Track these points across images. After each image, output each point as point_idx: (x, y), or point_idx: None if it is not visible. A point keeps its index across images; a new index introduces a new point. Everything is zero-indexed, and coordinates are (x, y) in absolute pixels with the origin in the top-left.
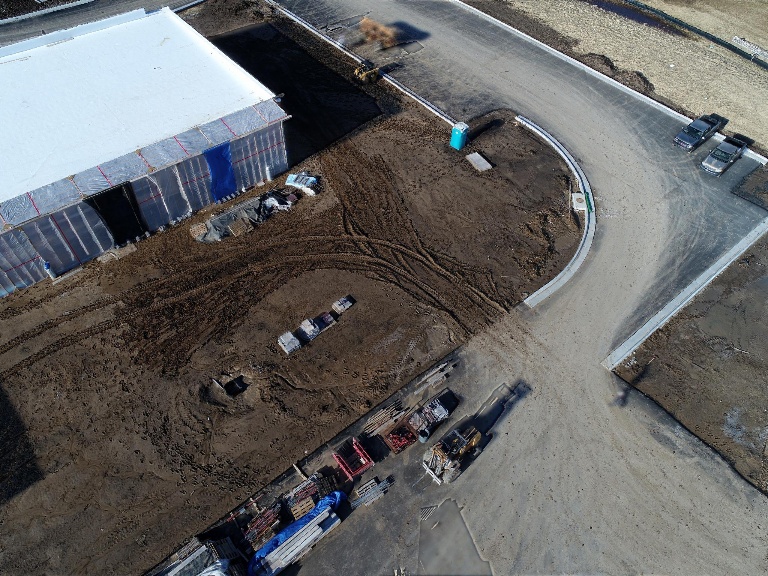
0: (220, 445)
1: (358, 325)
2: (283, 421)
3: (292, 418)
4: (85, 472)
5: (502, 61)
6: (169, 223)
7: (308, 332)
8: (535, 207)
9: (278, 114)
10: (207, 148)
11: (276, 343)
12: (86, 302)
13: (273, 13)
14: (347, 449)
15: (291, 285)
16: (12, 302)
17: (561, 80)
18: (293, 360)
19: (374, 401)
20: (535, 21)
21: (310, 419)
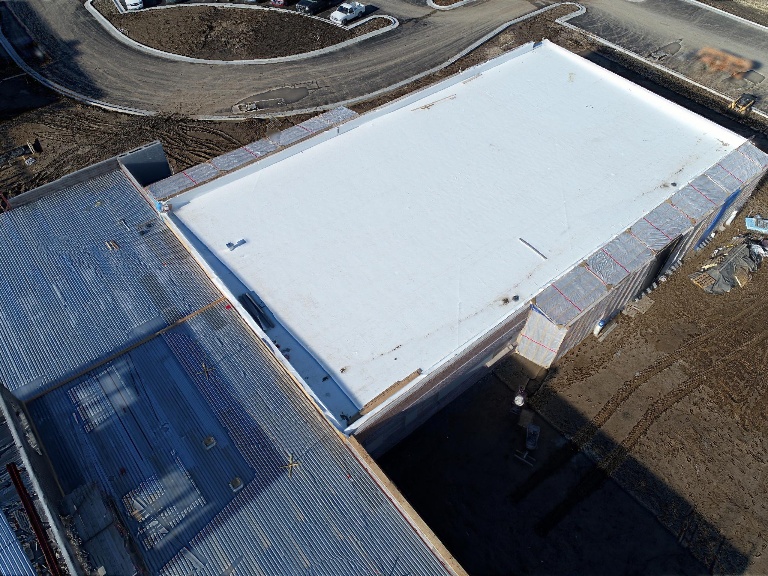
0: None
1: None
2: None
3: None
4: None
5: None
6: (665, 272)
7: None
8: None
9: (765, 158)
10: (727, 196)
11: None
12: (648, 361)
13: (587, 40)
14: None
15: None
16: (573, 362)
17: None
18: None
19: None
20: None
21: None
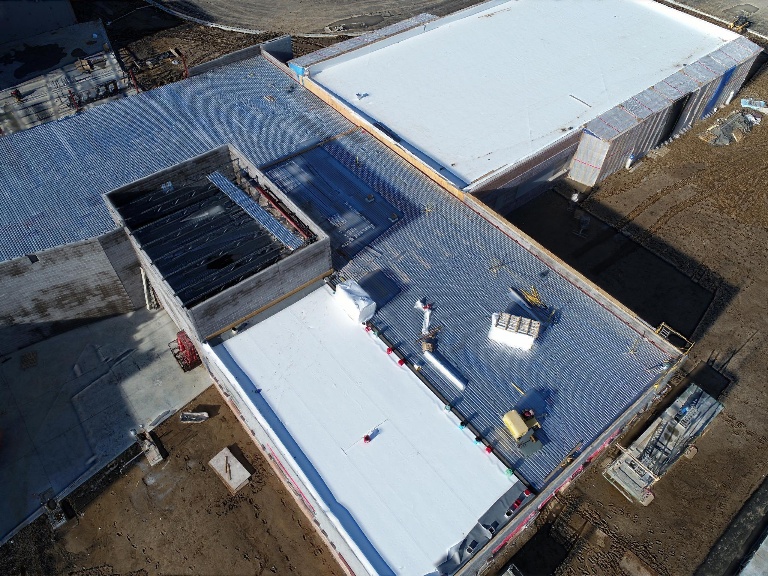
0: None
1: None
2: None
3: None
4: None
5: None
6: (679, 132)
7: None
8: None
9: (756, 47)
10: (725, 70)
11: None
12: (667, 184)
13: None
14: None
15: None
16: (611, 183)
17: None
18: None
19: None
20: None
21: None
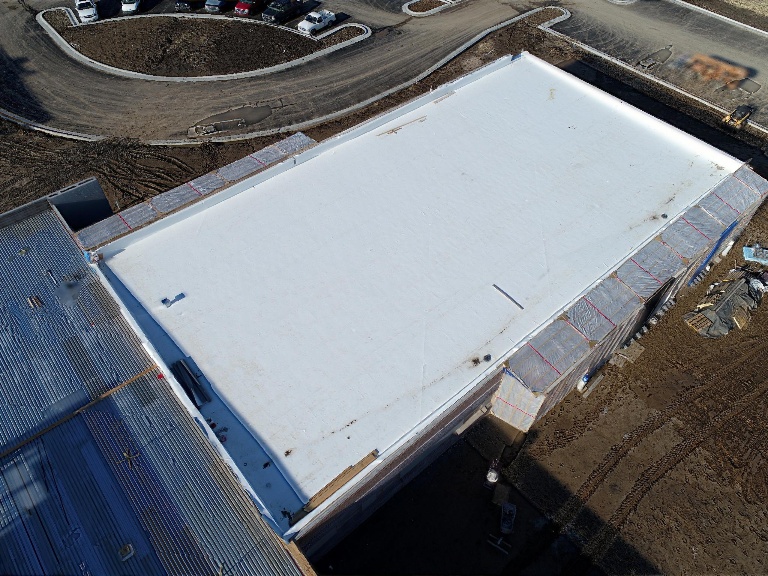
0: None
1: None
2: None
3: None
4: None
5: None
6: (656, 313)
7: None
8: None
9: (764, 184)
10: (723, 230)
11: None
12: (638, 420)
13: (572, 48)
14: None
15: None
16: (555, 423)
17: None
18: None
19: None
20: None
21: None
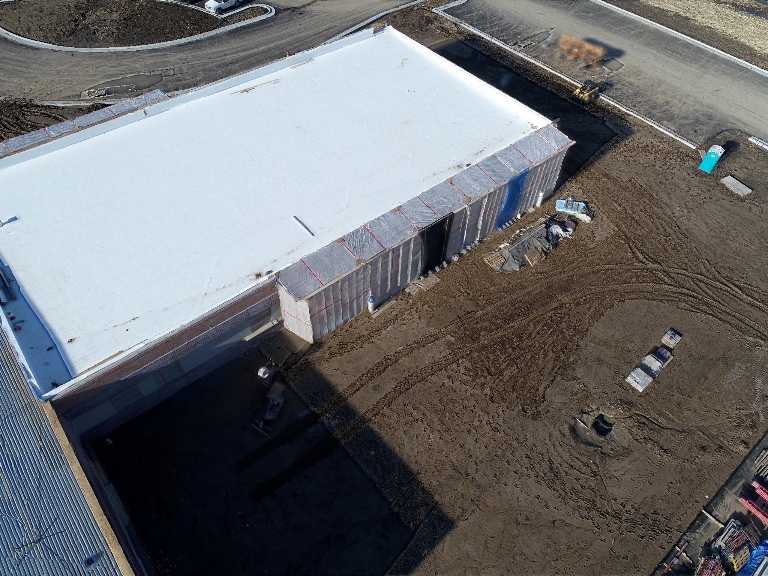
0: (617, 490)
1: (695, 360)
2: (668, 463)
3: (676, 460)
4: (495, 519)
5: (709, 79)
6: (460, 252)
7: (655, 368)
8: None
9: (563, 140)
10: (511, 176)
11: (622, 379)
12: (415, 336)
13: (458, 29)
14: (748, 493)
15: (609, 317)
16: (341, 337)
17: None
18: (647, 398)
19: (749, 441)
20: (726, 37)
21: (694, 461)
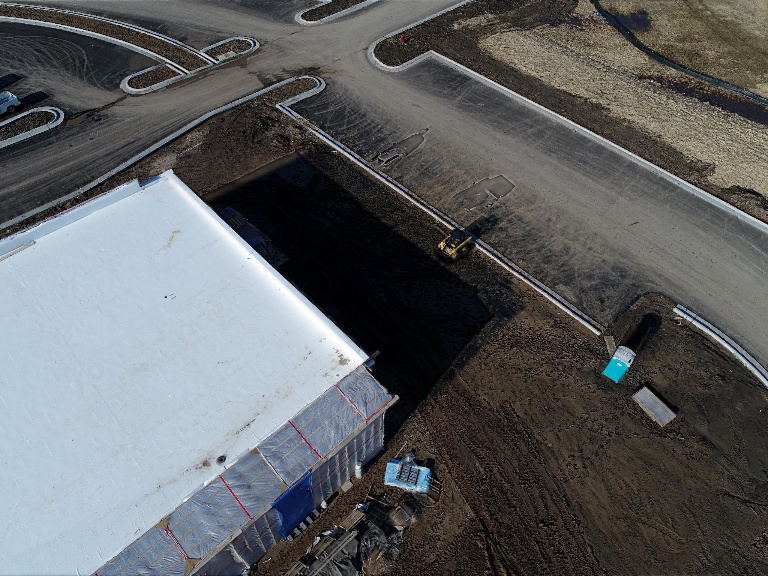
0: None
1: None
2: None
3: None
4: None
5: (624, 205)
6: None
7: None
8: (762, 496)
9: (378, 398)
10: (278, 494)
11: None
12: None
13: (303, 136)
14: None
15: None
16: None
17: (712, 235)
18: None
19: None
20: (647, 136)
21: None
